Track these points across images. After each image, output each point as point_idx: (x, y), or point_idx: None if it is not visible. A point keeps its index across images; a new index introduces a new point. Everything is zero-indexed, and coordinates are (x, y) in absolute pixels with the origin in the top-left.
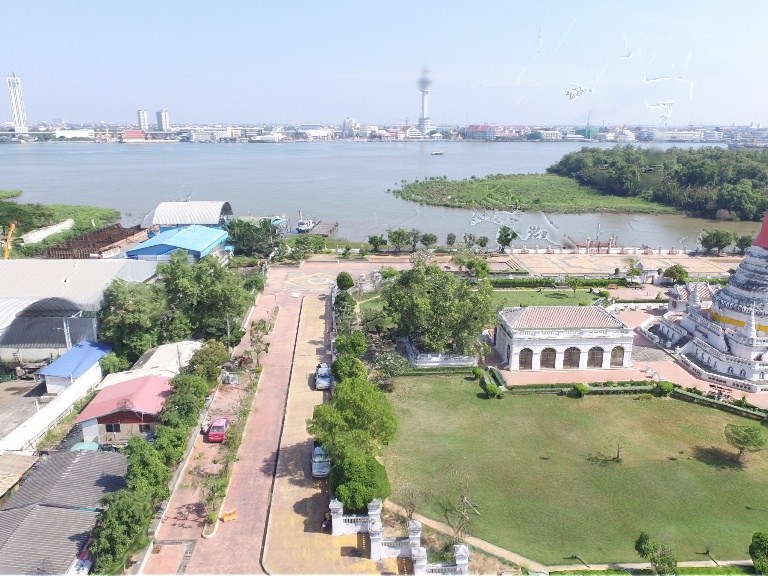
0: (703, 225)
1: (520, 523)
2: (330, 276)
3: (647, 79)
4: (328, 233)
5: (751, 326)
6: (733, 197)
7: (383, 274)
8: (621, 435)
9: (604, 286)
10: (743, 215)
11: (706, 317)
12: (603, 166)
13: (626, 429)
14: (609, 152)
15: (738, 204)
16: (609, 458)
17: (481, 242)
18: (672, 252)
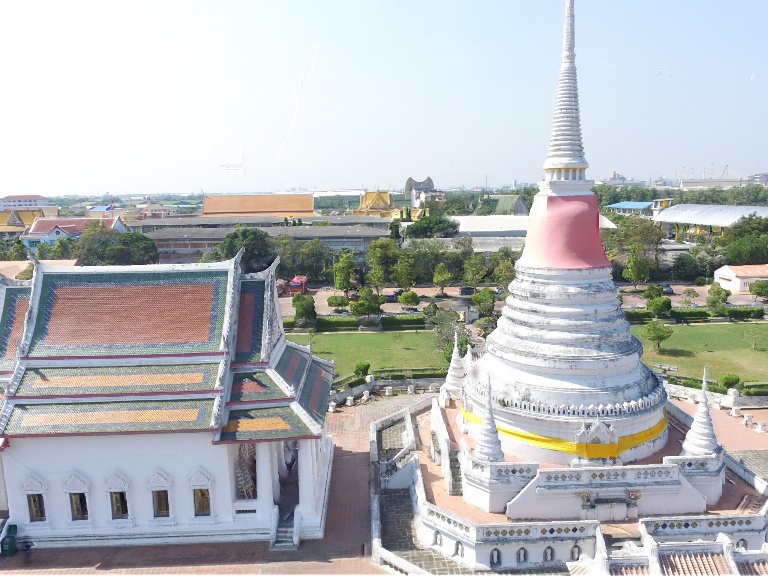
0: None
1: None
2: None
3: None
4: None
5: None
6: None
7: None
8: (760, 361)
9: None
10: None
11: (673, 434)
12: None
13: (758, 365)
14: None
15: None
16: (762, 351)
17: None
18: None
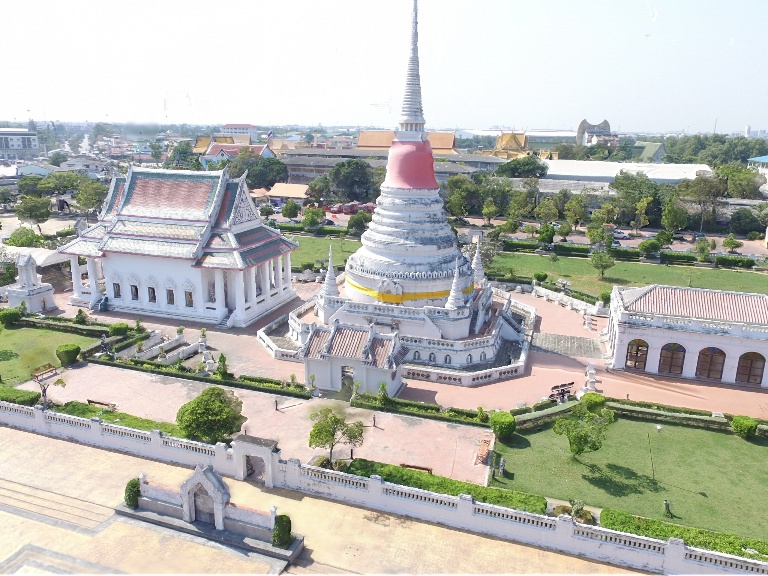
0: None
1: (766, 280)
2: None
3: None
4: None
5: None
6: None
7: None
8: None
9: None
10: None
11: None
12: None
13: None
14: None
15: None
16: None
17: None
18: None
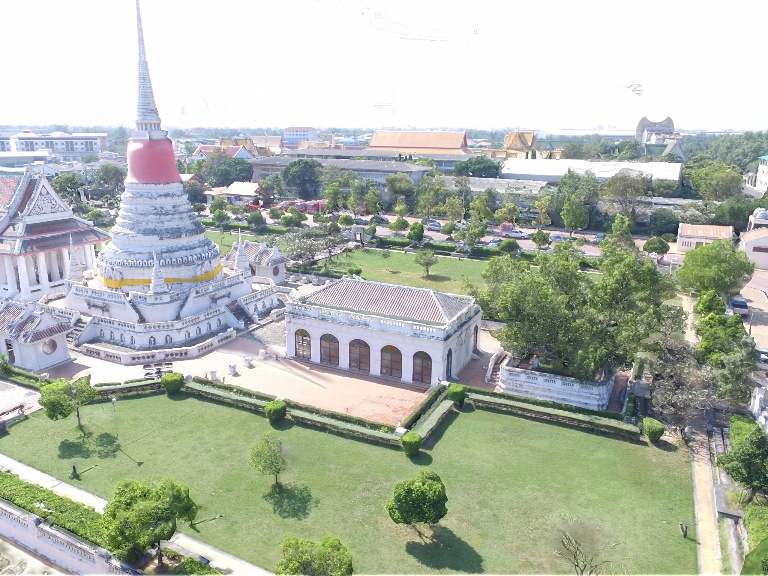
0: None
1: None
2: None
3: None
4: None
5: None
6: None
7: None
8: None
9: None
10: None
11: None
12: None
13: (465, 293)
14: None
15: None
16: None
17: None
18: None
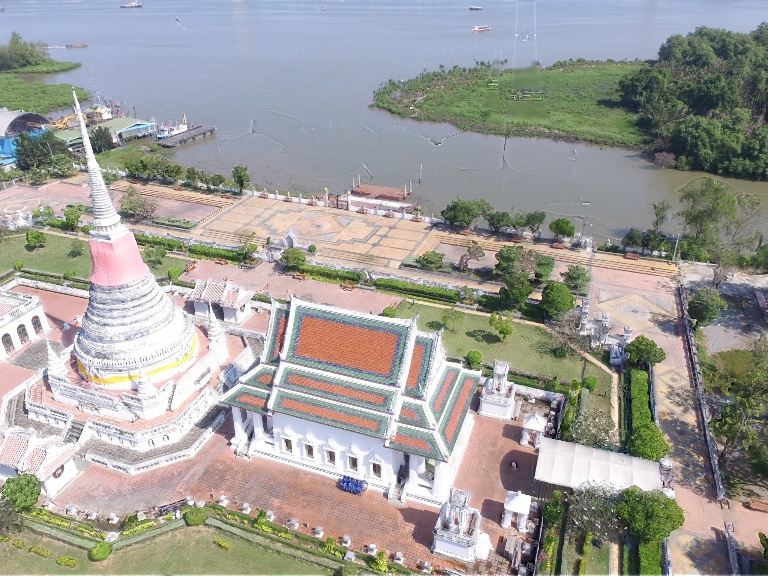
0: (635, 170)
1: None
2: (36, 203)
3: (332, 2)
4: (174, 143)
5: (48, 360)
6: (687, 136)
7: (33, 213)
8: None
9: (221, 258)
10: (698, 162)
11: None
12: (490, 85)
13: None
14: (488, 69)
15: (694, 147)
16: None
17: (213, 181)
18: (416, 219)
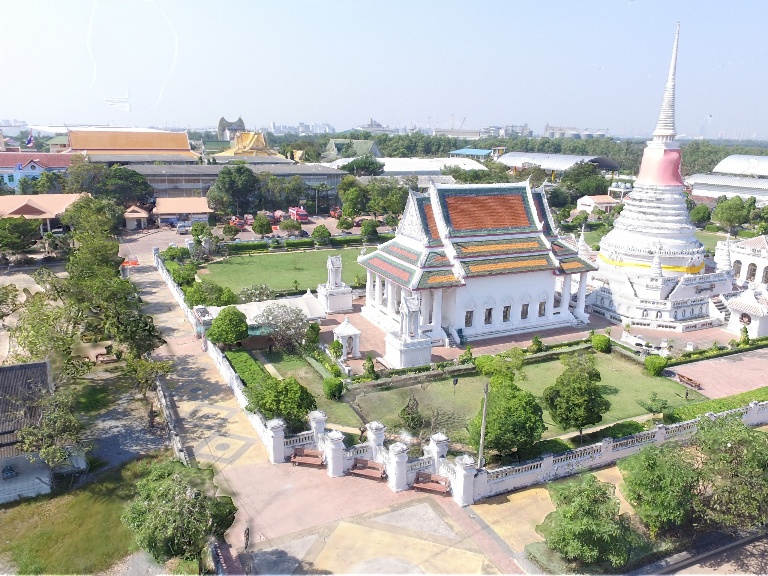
0: None
1: None
2: None
3: None
4: None
5: None
6: None
7: None
8: None
9: None
10: None
11: None
12: None
13: None
14: None
15: None
16: None
17: None
18: None
